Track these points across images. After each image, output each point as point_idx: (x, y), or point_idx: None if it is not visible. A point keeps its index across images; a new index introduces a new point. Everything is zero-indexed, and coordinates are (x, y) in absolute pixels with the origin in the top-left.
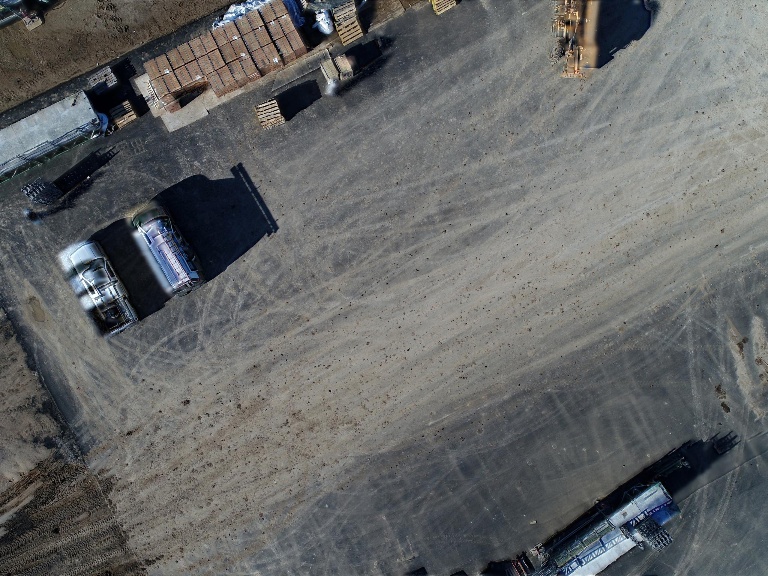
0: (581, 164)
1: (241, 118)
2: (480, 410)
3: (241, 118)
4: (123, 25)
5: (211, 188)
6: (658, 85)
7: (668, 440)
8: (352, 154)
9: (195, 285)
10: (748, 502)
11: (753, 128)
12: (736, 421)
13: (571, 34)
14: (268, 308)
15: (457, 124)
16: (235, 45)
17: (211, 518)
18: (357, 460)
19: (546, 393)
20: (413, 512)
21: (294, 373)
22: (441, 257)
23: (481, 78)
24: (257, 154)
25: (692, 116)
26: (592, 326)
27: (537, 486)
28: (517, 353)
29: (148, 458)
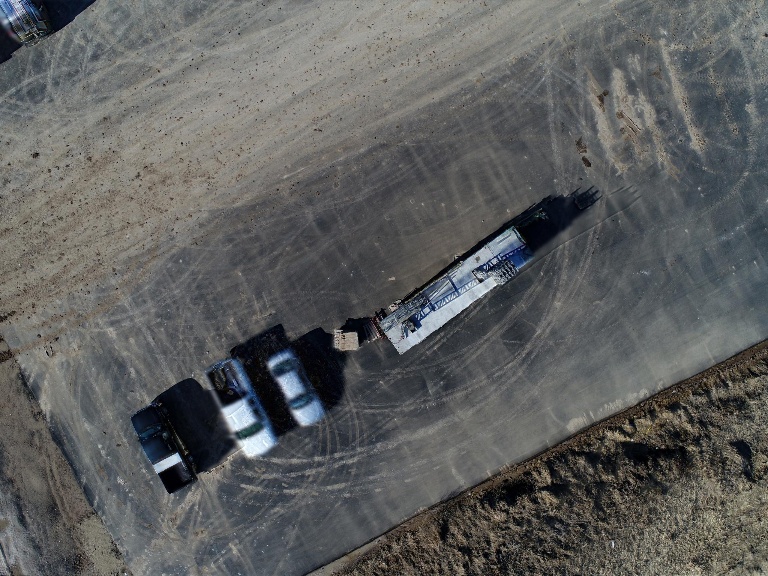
0: None
1: None
2: (336, 163)
3: None
4: None
5: None
6: None
7: (528, 194)
8: None
9: (43, 35)
10: (610, 259)
11: None
12: (597, 176)
13: None
14: (118, 59)
15: None
16: None
17: (63, 273)
18: (211, 214)
19: (403, 146)
20: (269, 267)
21: (145, 125)
22: (294, 7)
23: None
24: None
25: None
26: (449, 77)
27: (395, 242)
28: (373, 105)
29: None
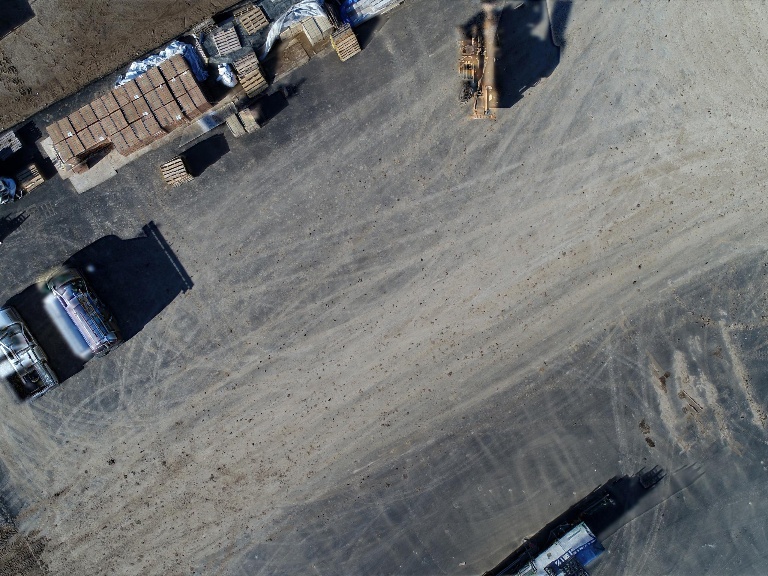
0: (495, 206)
1: (150, 176)
2: (404, 456)
3: (150, 176)
4: (26, 88)
5: (124, 248)
6: (570, 122)
7: (593, 477)
8: (263, 207)
9: (113, 345)
10: (676, 534)
11: (668, 161)
12: (661, 455)
13: (479, 74)
14: (187, 365)
15: (368, 171)
16: (137, 104)
17: (142, 574)
18: (284, 511)
19: (469, 436)
20: (342, 559)
21: (217, 428)
22: (358, 306)
23: (390, 123)
24: (168, 211)
25: (605, 152)
26: (512, 368)
27: (464, 528)
28: (438, 398)
29: (76, 518)
